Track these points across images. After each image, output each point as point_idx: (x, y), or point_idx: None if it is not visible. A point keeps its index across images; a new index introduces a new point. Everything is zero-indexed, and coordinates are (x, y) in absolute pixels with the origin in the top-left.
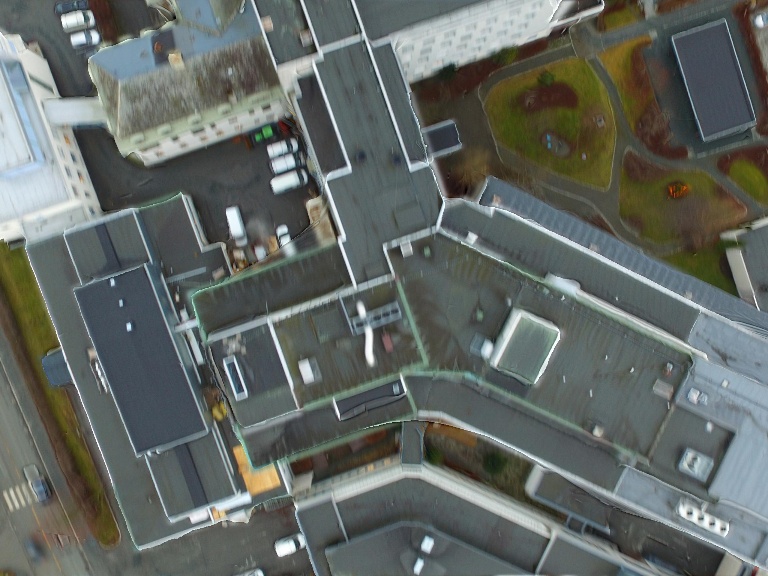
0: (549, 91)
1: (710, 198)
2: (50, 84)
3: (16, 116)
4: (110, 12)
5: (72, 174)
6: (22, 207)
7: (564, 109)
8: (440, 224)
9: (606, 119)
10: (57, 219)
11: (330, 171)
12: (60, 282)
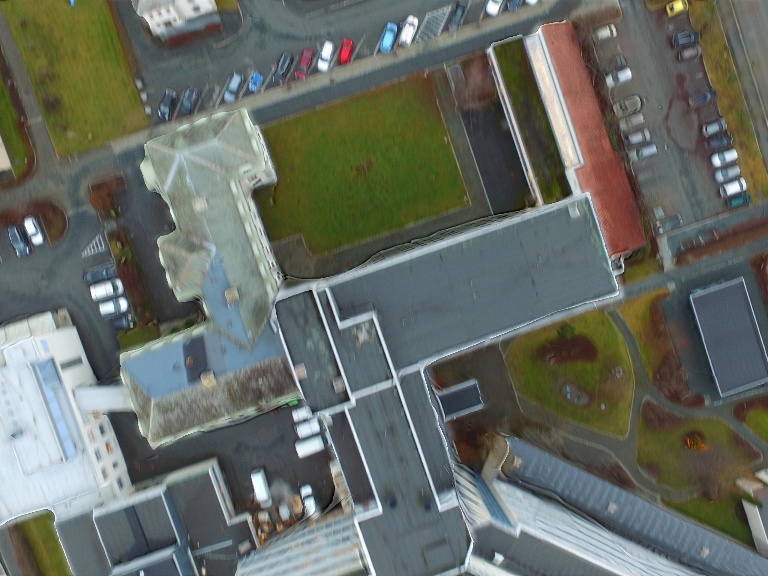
0: (569, 346)
1: (726, 446)
2: (79, 354)
3: (49, 419)
4: (138, 277)
5: (101, 454)
6: (53, 496)
7: (584, 363)
8: (468, 562)
9: (625, 369)
10: (86, 496)
11: (360, 505)
12: (88, 557)
